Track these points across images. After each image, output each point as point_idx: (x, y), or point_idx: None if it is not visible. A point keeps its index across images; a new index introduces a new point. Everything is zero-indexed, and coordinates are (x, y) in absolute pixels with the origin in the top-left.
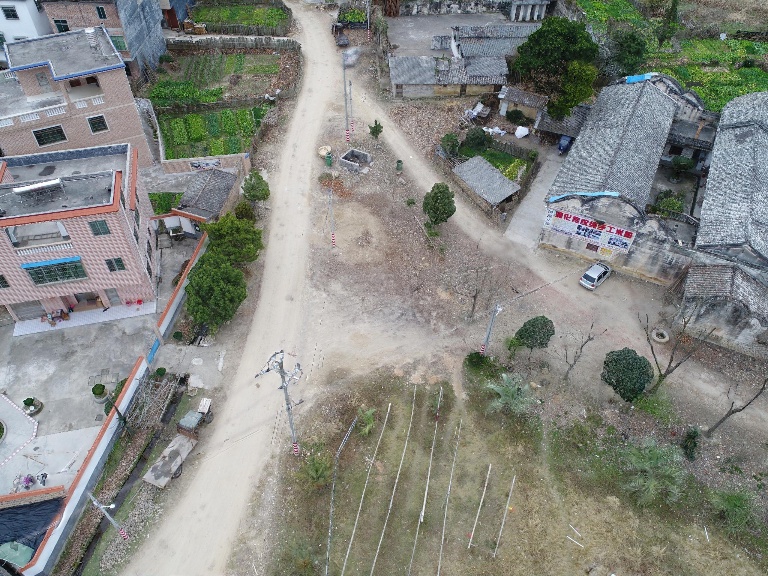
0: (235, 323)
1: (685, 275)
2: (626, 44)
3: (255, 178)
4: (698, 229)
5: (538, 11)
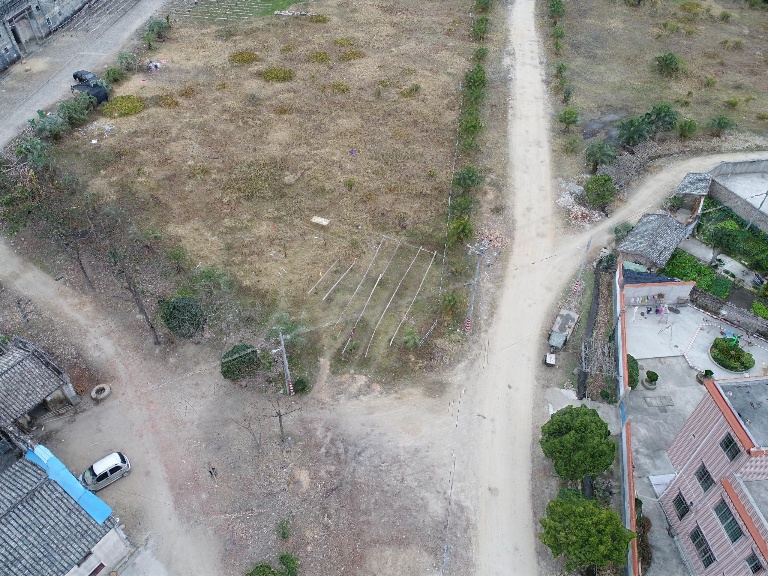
0: None
1: None
2: None
3: None
4: None
5: None
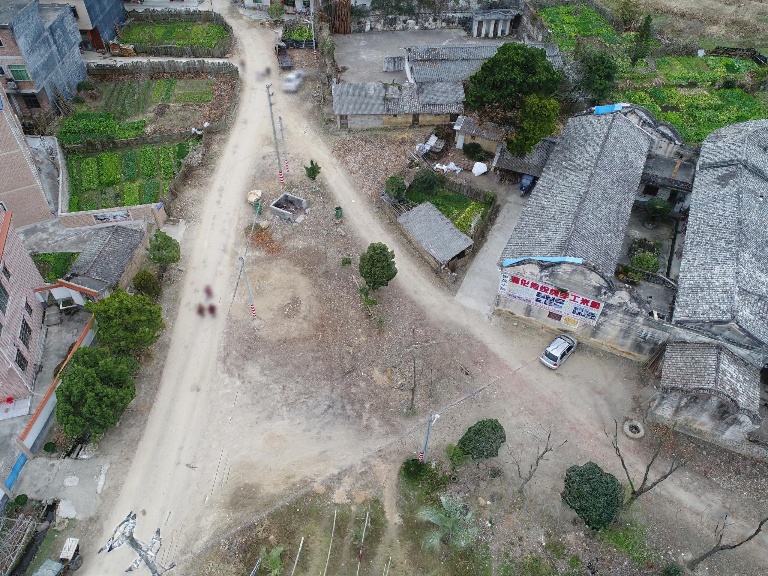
0: (126, 424)
1: (662, 352)
2: (595, 67)
3: (160, 239)
4: (676, 295)
5: (502, 26)
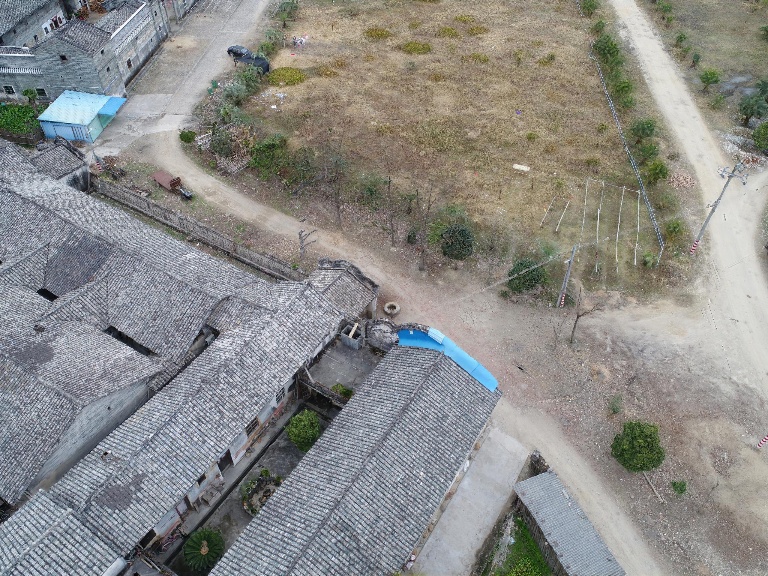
0: None
1: None
2: None
3: None
4: None
5: None
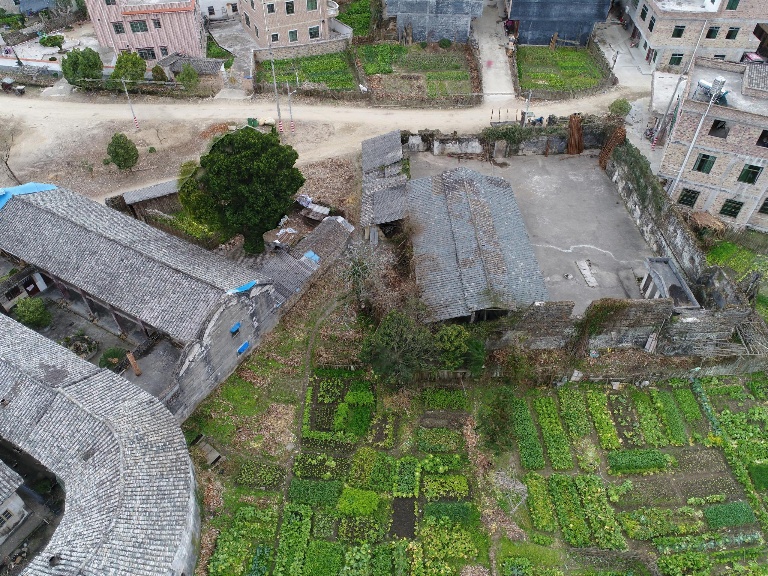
0: (86, 98)
1: None
2: None
3: None
4: None
5: None
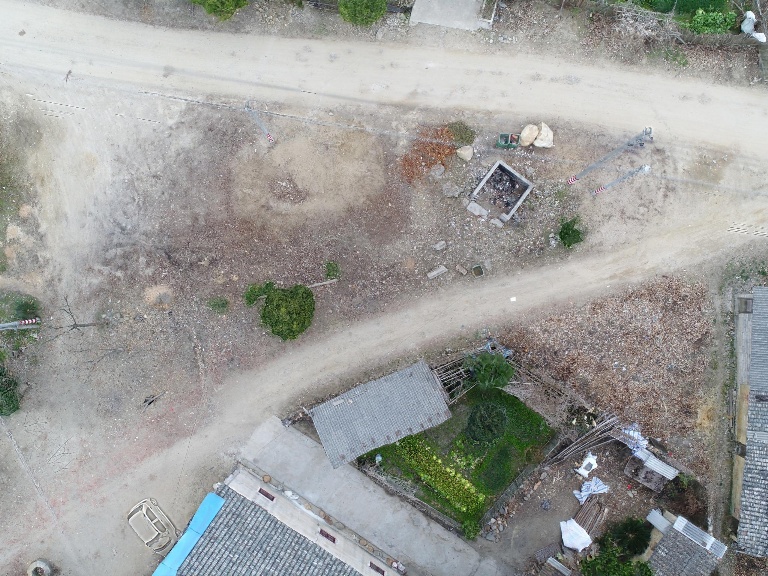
0: None
1: None
2: None
3: None
4: None
5: None
